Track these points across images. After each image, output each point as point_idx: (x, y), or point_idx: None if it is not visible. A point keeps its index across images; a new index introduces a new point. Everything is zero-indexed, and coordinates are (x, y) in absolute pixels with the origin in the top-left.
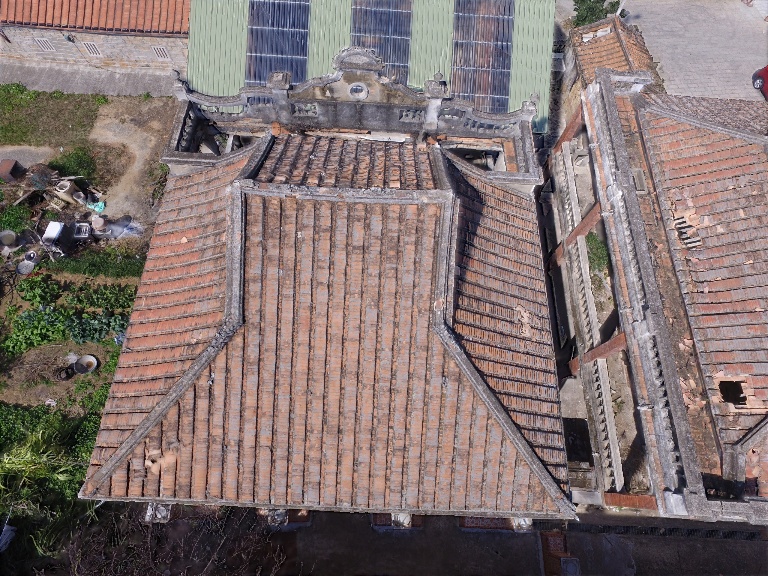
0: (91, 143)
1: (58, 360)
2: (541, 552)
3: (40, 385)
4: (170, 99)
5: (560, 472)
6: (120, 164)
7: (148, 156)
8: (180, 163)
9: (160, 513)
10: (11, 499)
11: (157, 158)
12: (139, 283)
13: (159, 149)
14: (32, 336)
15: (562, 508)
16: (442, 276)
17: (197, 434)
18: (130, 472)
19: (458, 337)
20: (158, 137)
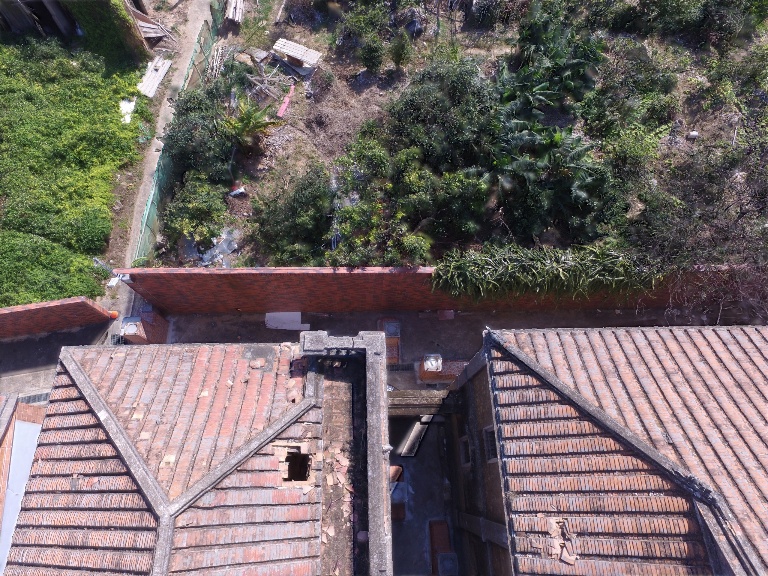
0: None
1: None
2: (399, 347)
3: None
4: None
5: (502, 367)
6: None
7: None
8: None
9: None
10: None
11: None
12: None
13: None
14: None
15: (502, 336)
16: (760, 568)
17: None
18: None
19: (675, 493)
20: None
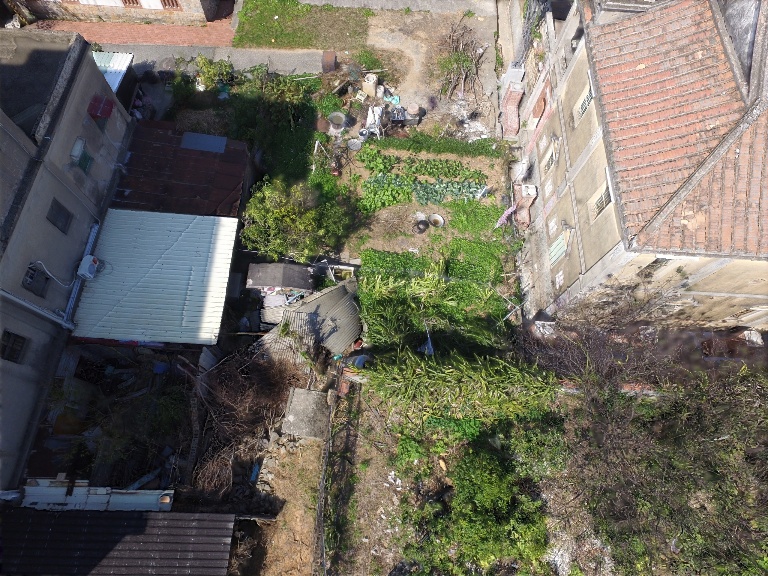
0: (371, 48)
1: (408, 218)
2: None
3: (399, 237)
4: (428, 13)
5: None
6: (403, 65)
7: (424, 60)
8: (620, 8)
9: (548, 331)
10: (423, 315)
11: (433, 61)
12: (457, 159)
13: (432, 54)
14: (385, 196)
15: None
16: None
17: (724, 199)
18: (670, 229)
19: None
20: (428, 44)
